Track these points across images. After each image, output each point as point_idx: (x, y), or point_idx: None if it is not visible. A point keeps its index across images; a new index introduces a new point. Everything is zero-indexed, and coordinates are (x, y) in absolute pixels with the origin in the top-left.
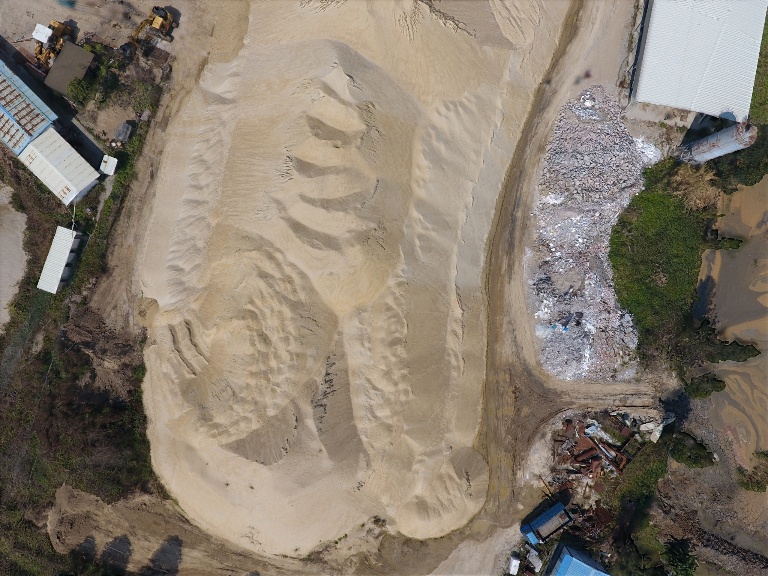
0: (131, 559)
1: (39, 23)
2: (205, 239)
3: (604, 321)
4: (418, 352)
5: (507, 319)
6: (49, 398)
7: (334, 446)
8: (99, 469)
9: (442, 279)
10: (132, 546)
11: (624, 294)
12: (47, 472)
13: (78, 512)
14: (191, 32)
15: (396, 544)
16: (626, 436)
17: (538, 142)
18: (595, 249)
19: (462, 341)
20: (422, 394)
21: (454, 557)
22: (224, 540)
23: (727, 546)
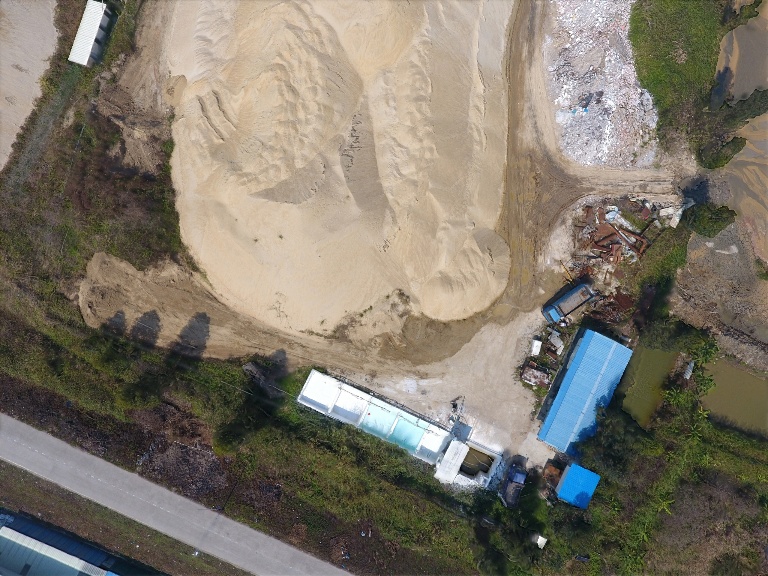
0: (160, 335)
1: None
2: (232, 11)
3: (624, 97)
4: (442, 116)
5: (527, 105)
6: (81, 162)
7: (361, 196)
8: (130, 229)
9: (464, 53)
10: (161, 322)
11: (644, 72)
12: (78, 245)
13: (109, 284)
14: None
15: (419, 325)
16: (646, 223)
17: None
18: (615, 26)
19: (484, 117)
20: (446, 156)
21: (477, 340)
22: (251, 318)
23: (746, 337)
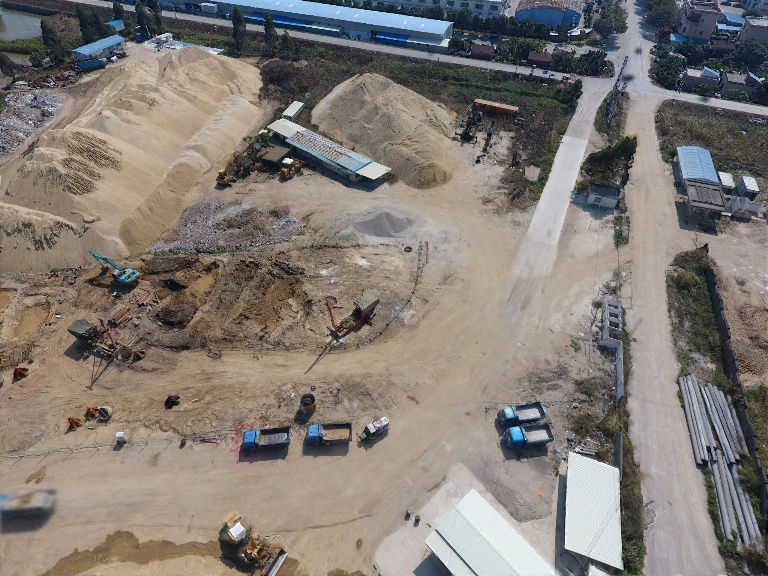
0: None
1: (301, 180)
2: None
3: None
4: None
5: None
6: None
7: None
8: None
9: None
10: None
11: (3, 105)
12: None
13: None
14: (210, 182)
15: None
16: None
17: (12, 156)
18: (7, 114)
19: None
20: None
21: None
22: None
23: None
